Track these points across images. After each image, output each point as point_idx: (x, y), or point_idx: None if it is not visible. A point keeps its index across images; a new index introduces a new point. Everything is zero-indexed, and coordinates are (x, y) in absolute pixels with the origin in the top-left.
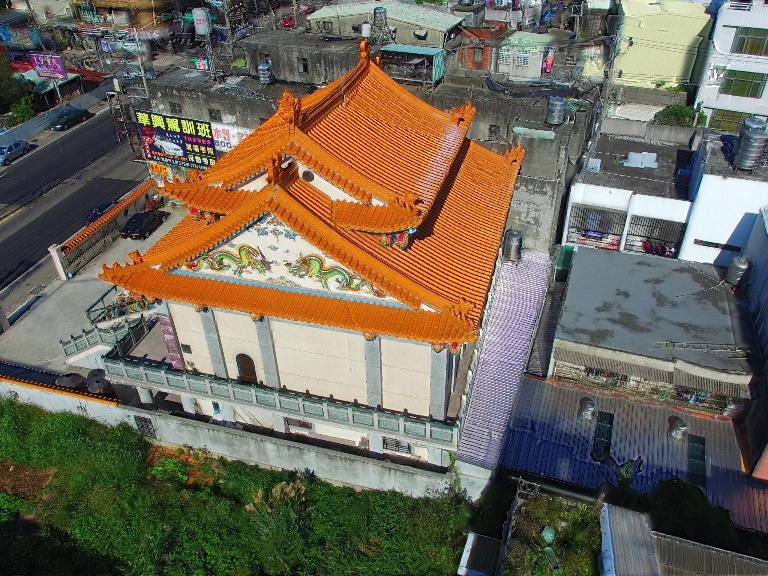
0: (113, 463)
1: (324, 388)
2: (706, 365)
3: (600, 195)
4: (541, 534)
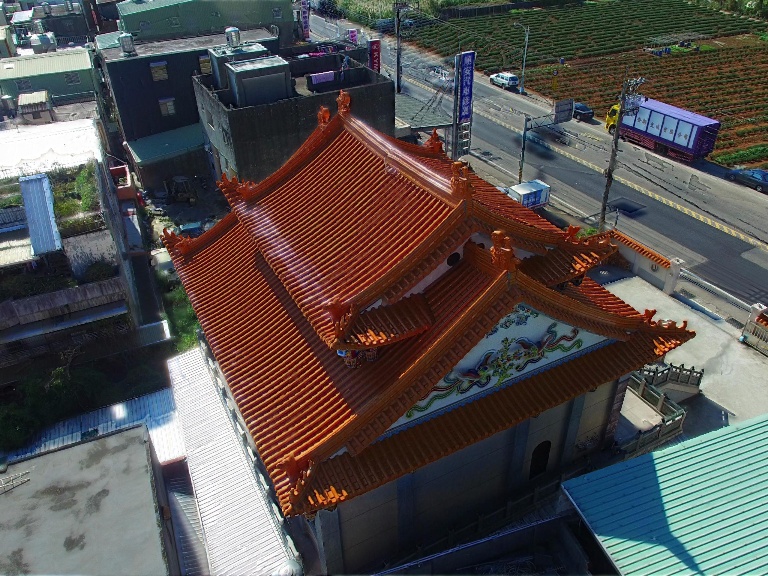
0: None
1: None
2: None
3: None
4: None
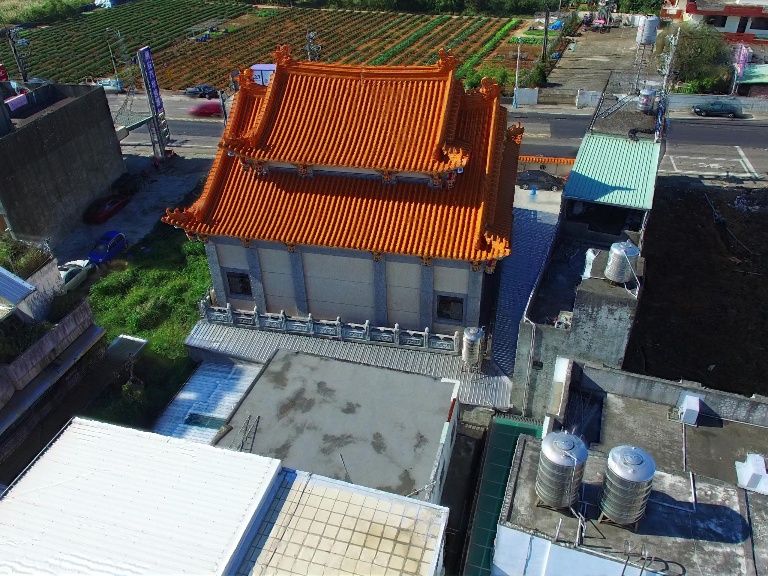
0: None
1: None
2: None
3: None
4: None
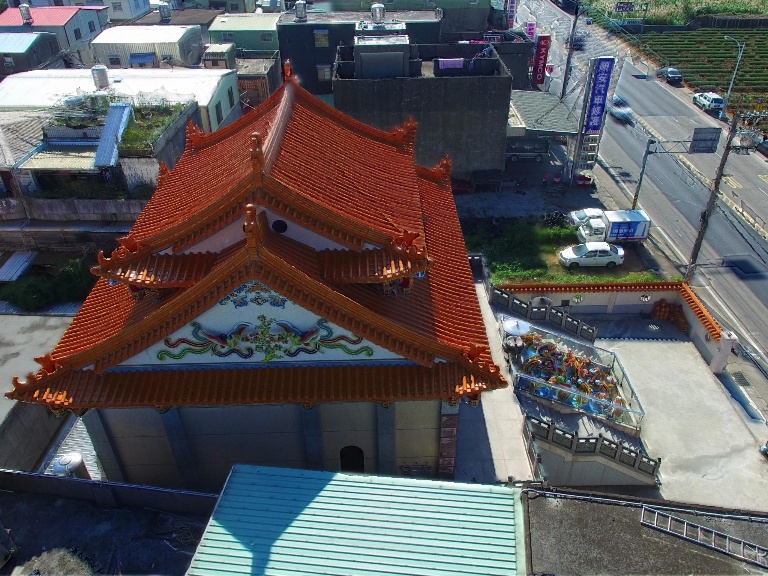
0: None
1: None
2: None
3: None
4: None
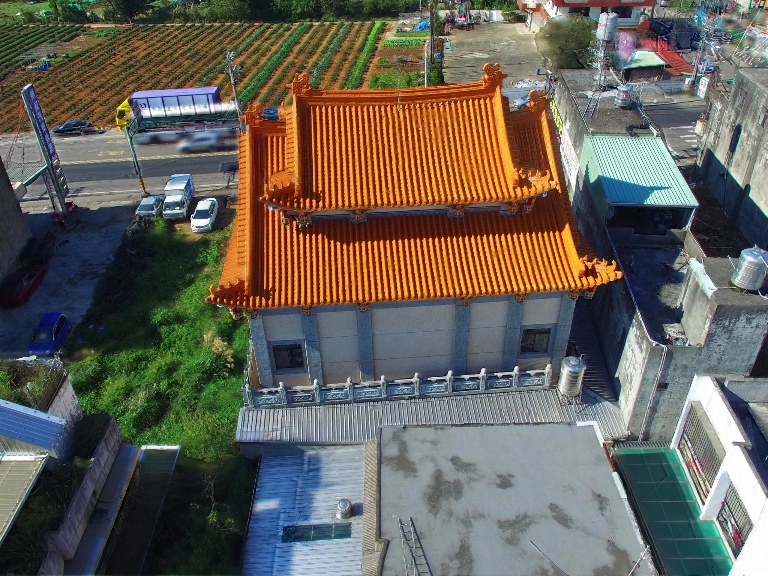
0: None
1: None
2: None
3: (720, 415)
4: None
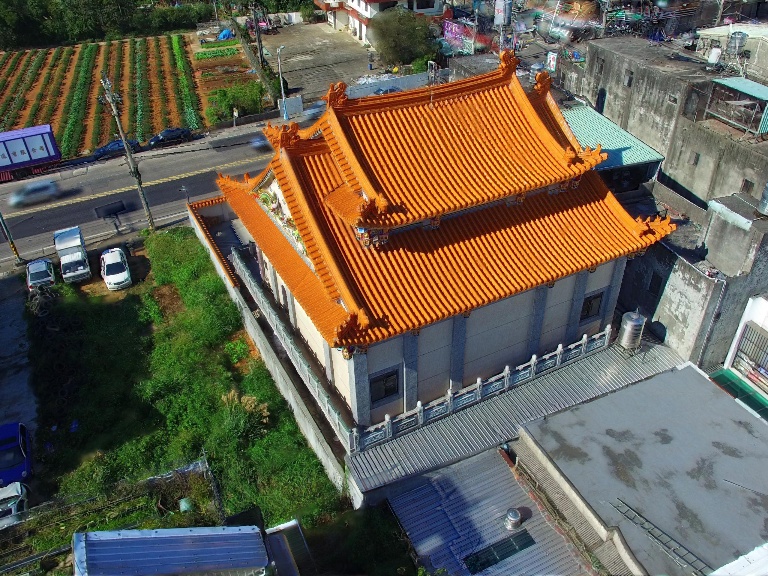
0: (206, 322)
1: (313, 344)
2: (641, 560)
3: None
4: (179, 500)
